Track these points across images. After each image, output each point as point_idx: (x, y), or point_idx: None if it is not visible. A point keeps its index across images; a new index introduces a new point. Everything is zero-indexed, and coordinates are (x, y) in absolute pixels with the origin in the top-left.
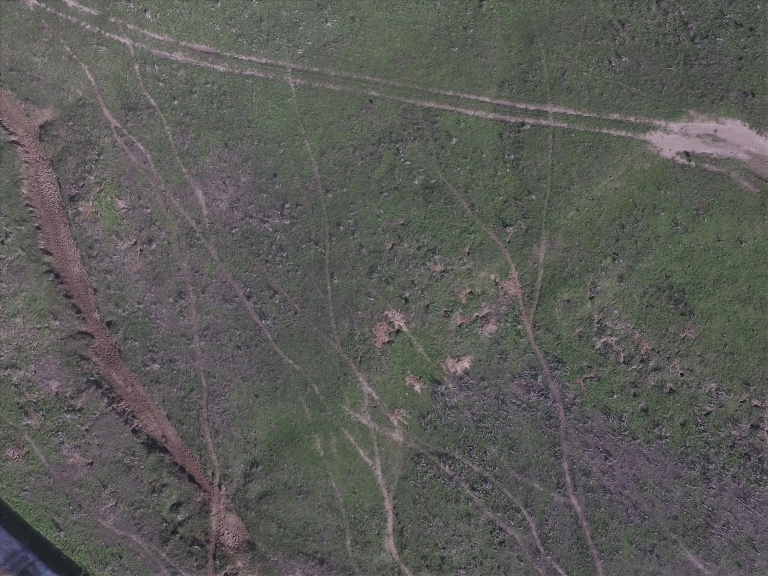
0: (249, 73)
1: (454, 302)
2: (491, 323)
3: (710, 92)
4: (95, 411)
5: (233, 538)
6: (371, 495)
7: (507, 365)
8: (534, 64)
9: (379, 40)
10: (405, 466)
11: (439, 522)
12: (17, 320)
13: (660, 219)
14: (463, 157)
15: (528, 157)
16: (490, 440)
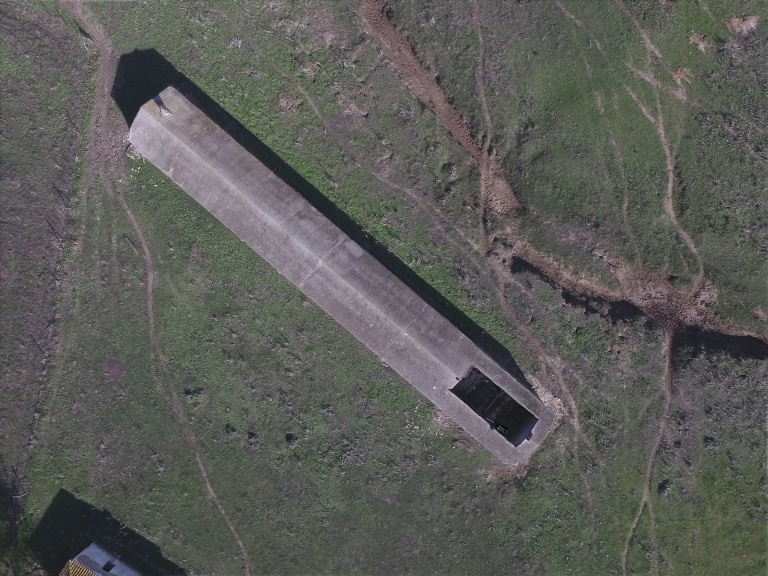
0: None
1: None
2: None
3: None
4: (370, 63)
5: (501, 204)
6: (653, 153)
7: None
8: None
9: None
10: (688, 125)
11: (724, 181)
12: None
13: None
14: None
15: None
16: None
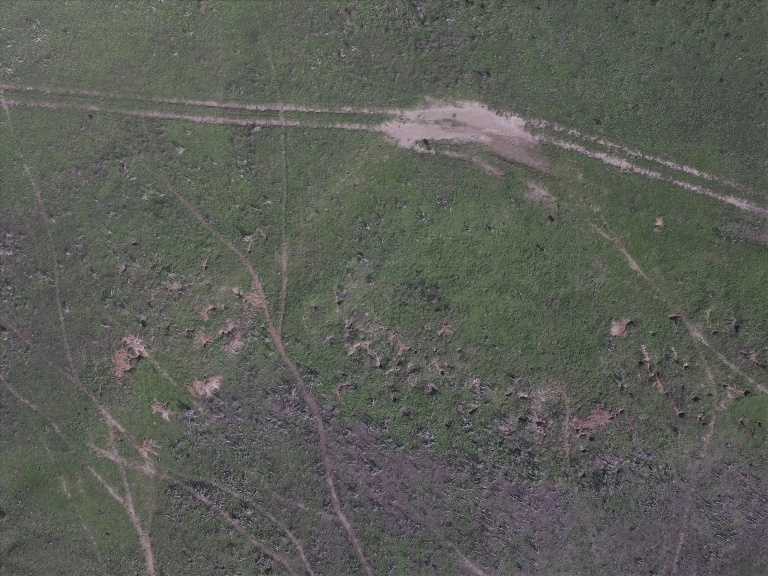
0: None
1: (196, 321)
2: (236, 339)
3: (443, 76)
4: None
5: None
6: (125, 534)
7: (258, 381)
8: (261, 63)
9: (95, 52)
10: (159, 500)
11: (199, 555)
12: None
13: (403, 213)
14: (193, 167)
15: (260, 161)
16: (247, 463)
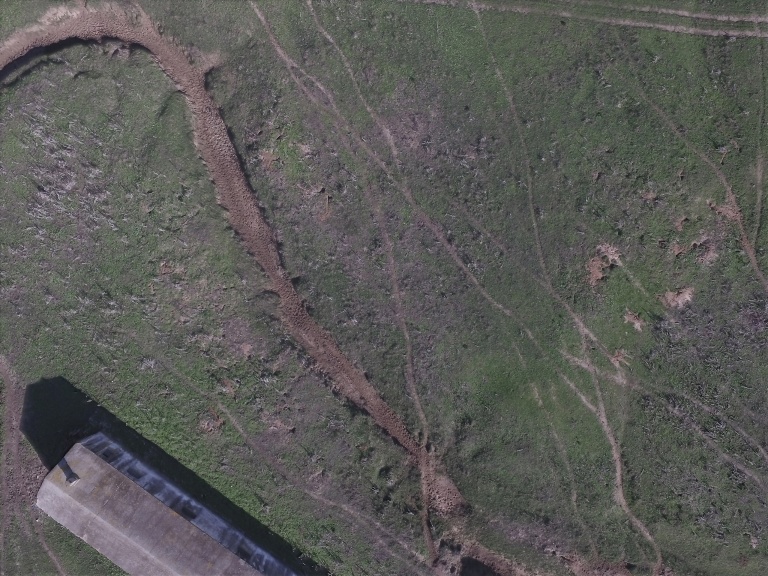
0: (430, 2)
1: (670, 231)
2: (712, 251)
3: None
4: (293, 374)
5: (445, 502)
6: (597, 444)
7: (731, 295)
8: None
9: None
10: (631, 410)
11: (673, 467)
12: (201, 281)
13: None
14: (667, 76)
15: (737, 71)
16: (719, 376)
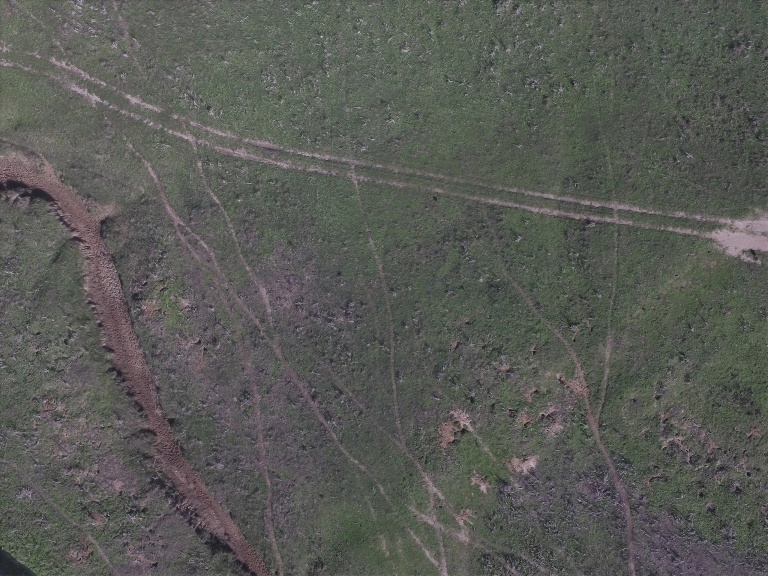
0: (312, 170)
1: (520, 401)
2: (557, 423)
3: None
4: (159, 512)
5: None
6: None
7: (573, 465)
8: (598, 161)
9: (443, 136)
10: (471, 567)
11: None
12: (80, 420)
13: (726, 318)
14: (528, 255)
15: (593, 255)
16: (556, 540)
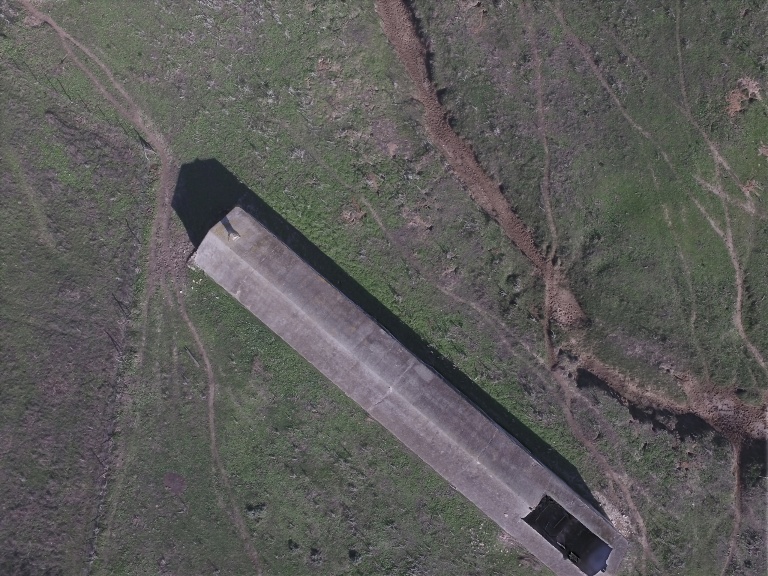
0: None
1: None
2: None
3: None
4: (435, 175)
5: (566, 315)
6: (721, 267)
7: None
8: None
9: None
10: (757, 238)
11: None
12: (355, 81)
13: None
14: None
15: None
16: None
